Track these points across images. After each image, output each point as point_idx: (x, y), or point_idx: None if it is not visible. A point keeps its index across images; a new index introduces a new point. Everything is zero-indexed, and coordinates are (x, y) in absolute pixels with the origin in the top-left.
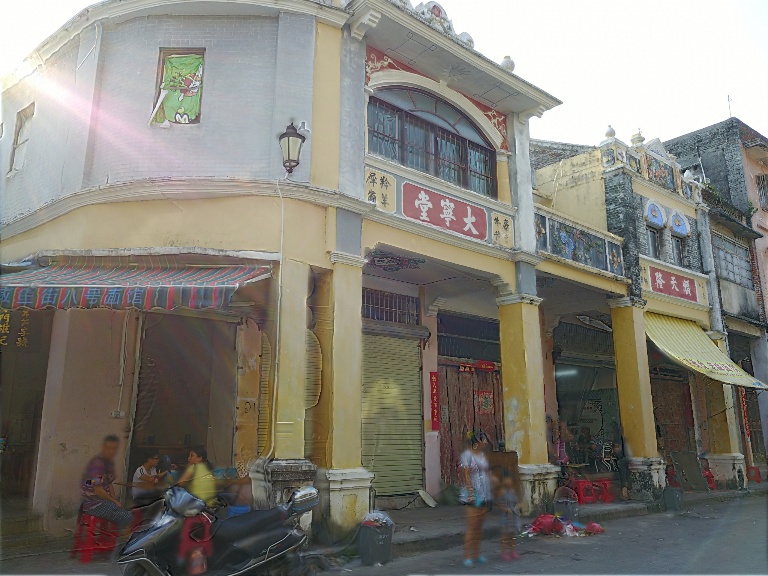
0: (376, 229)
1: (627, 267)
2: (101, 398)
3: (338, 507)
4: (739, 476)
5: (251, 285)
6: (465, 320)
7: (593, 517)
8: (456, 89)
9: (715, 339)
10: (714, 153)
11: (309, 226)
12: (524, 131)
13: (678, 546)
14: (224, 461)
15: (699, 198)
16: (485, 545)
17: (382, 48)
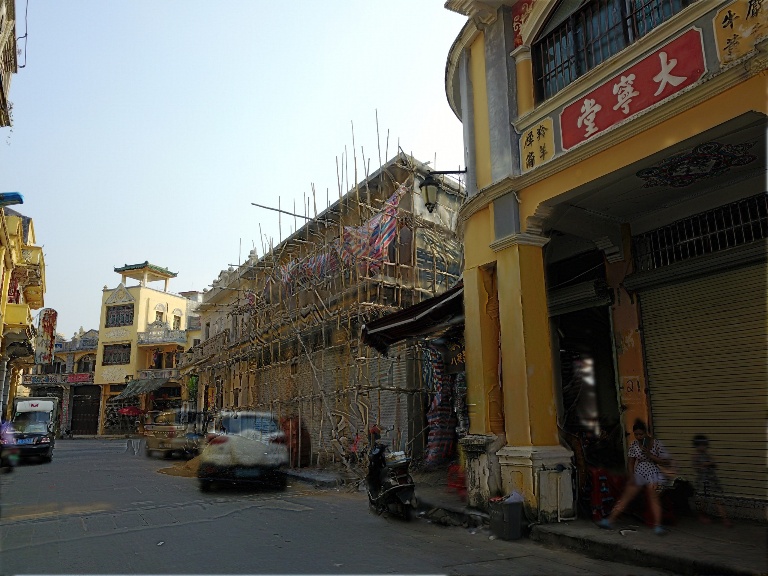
0: (536, 191)
1: None
2: None
3: (508, 481)
4: None
5: (447, 303)
6: None
7: None
8: None
9: None
10: None
11: (481, 231)
12: None
13: None
14: (614, 439)
15: None
16: (637, 573)
17: None
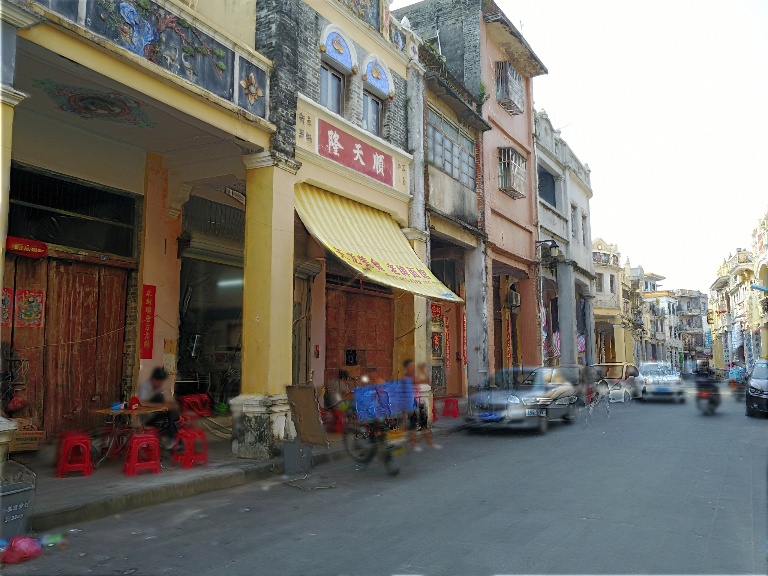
0: None
1: (273, 106)
2: None
3: None
4: (421, 413)
5: None
6: None
7: (102, 507)
8: None
9: (412, 239)
10: (453, 26)
11: None
12: None
13: None
14: None
15: (414, 54)
16: None
17: None
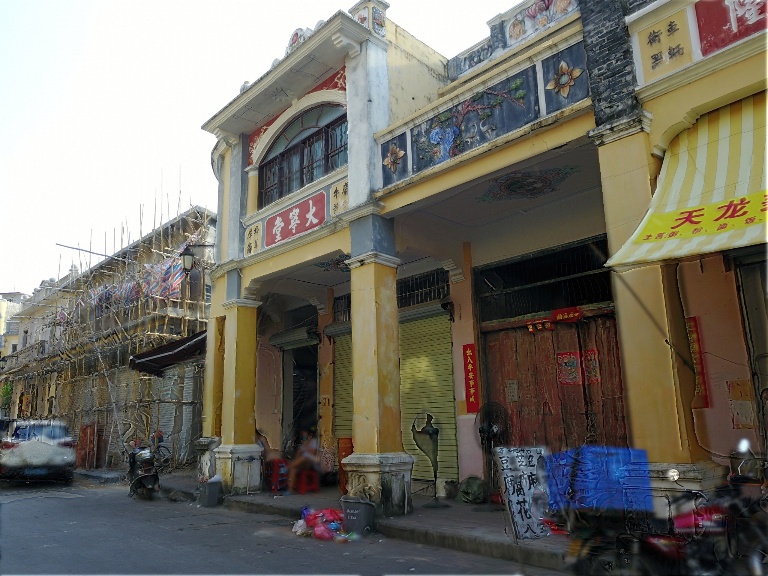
0: None
1: None
2: (267, 403)
3: None
4: None
5: (197, 341)
6: (532, 261)
7: (421, 535)
8: (302, 95)
9: None
10: None
11: None
12: (360, 61)
13: (212, 551)
14: None
15: None
16: None
17: (255, 127)
